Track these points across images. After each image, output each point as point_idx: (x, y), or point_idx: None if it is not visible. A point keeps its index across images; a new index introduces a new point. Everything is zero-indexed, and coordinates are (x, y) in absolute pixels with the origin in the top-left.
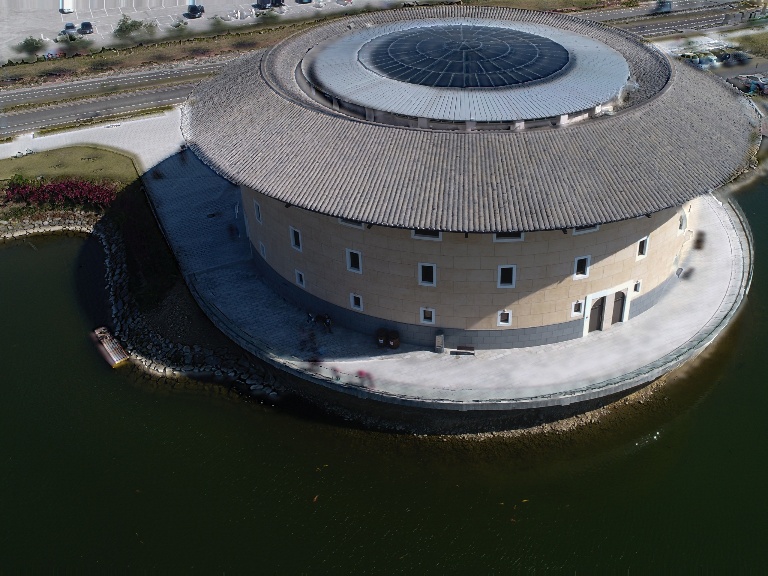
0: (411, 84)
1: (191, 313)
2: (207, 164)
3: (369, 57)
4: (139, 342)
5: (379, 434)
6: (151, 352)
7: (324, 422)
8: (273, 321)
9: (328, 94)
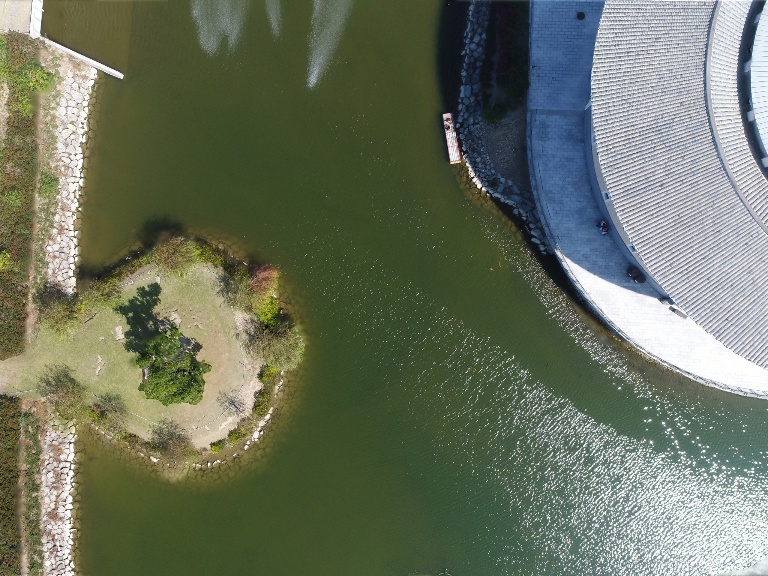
0: None
1: (518, 146)
2: (595, 132)
3: None
4: (471, 151)
5: (593, 323)
6: (477, 166)
7: (565, 294)
8: (573, 209)
9: (752, 103)
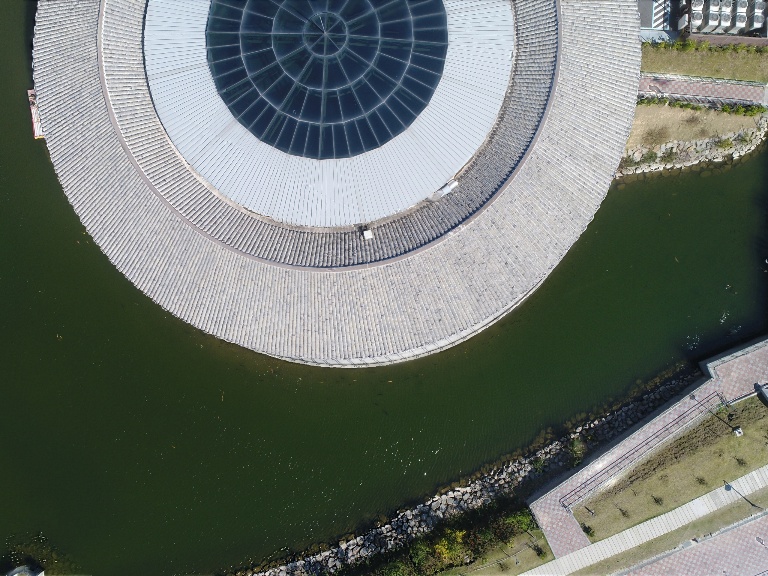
0: (221, 101)
1: None
2: None
3: (224, 0)
4: None
5: None
6: None
7: None
8: None
9: (146, 70)
